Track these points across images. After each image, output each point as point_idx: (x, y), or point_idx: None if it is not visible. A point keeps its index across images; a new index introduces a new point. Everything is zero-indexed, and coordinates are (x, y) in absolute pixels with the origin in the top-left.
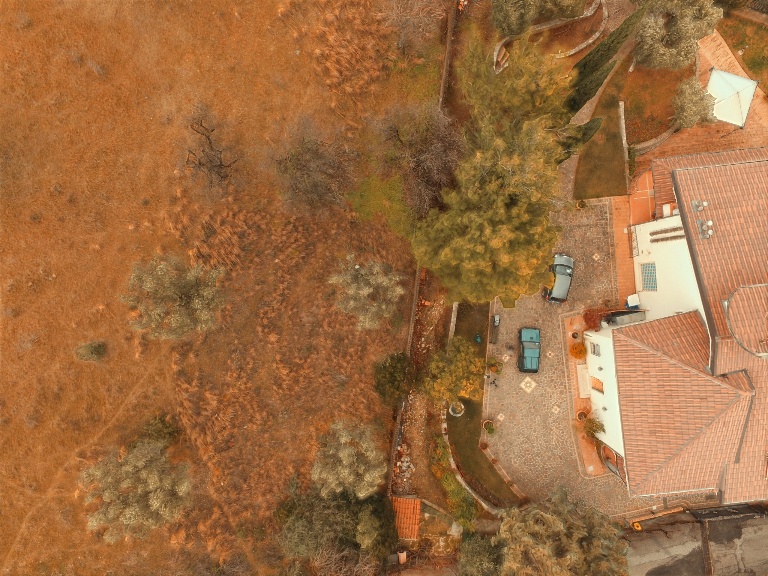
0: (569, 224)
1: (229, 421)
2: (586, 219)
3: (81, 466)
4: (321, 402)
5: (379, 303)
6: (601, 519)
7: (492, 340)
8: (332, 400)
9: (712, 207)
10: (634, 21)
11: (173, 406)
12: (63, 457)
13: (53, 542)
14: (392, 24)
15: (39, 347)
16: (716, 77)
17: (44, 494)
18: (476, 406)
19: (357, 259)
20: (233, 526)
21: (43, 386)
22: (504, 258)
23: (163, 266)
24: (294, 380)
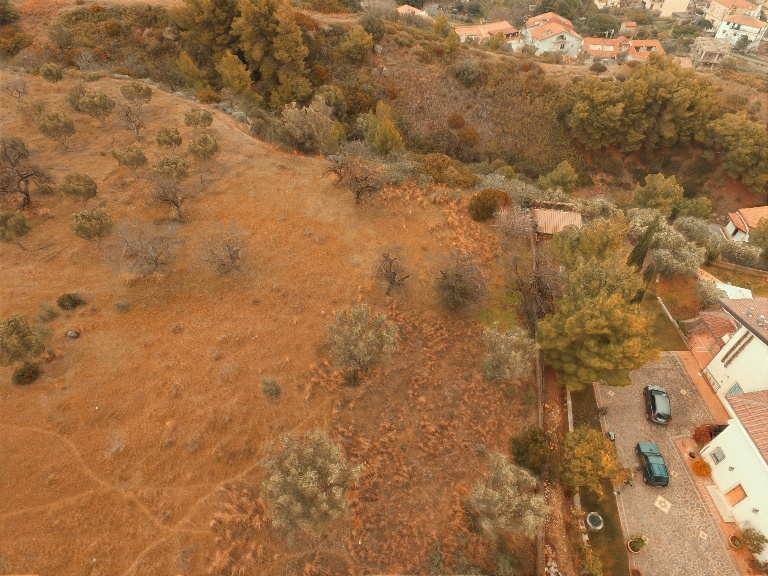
0: (650, 367)
1: (377, 469)
2: (662, 365)
3: (221, 500)
4: (463, 469)
5: None
6: None
7: None
8: (473, 469)
9: (759, 315)
10: (653, 225)
11: None
12: (207, 488)
13: None
14: (502, 230)
15: (225, 384)
16: (719, 285)
17: (173, 526)
18: (614, 524)
19: None
20: None
21: (216, 416)
22: (619, 310)
23: None
24: (438, 441)
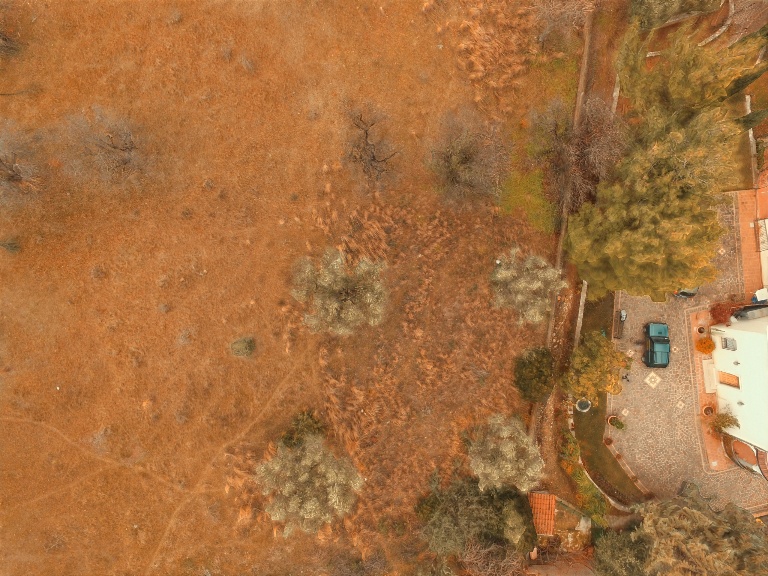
0: None
1: (375, 416)
2: None
3: (228, 462)
4: (461, 397)
5: (541, 297)
6: (743, 514)
7: (618, 335)
8: (472, 395)
9: None
10: None
11: (319, 401)
12: (211, 453)
13: (200, 538)
14: (543, 17)
15: (189, 343)
16: None
17: (192, 490)
18: (600, 401)
19: (499, 254)
20: (373, 522)
21: (193, 382)
22: (687, 251)
23: (339, 260)
24: (437, 375)
